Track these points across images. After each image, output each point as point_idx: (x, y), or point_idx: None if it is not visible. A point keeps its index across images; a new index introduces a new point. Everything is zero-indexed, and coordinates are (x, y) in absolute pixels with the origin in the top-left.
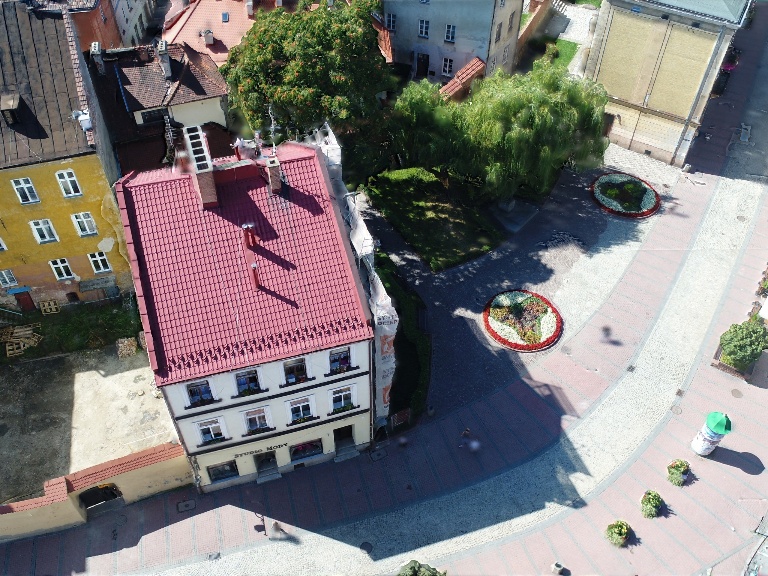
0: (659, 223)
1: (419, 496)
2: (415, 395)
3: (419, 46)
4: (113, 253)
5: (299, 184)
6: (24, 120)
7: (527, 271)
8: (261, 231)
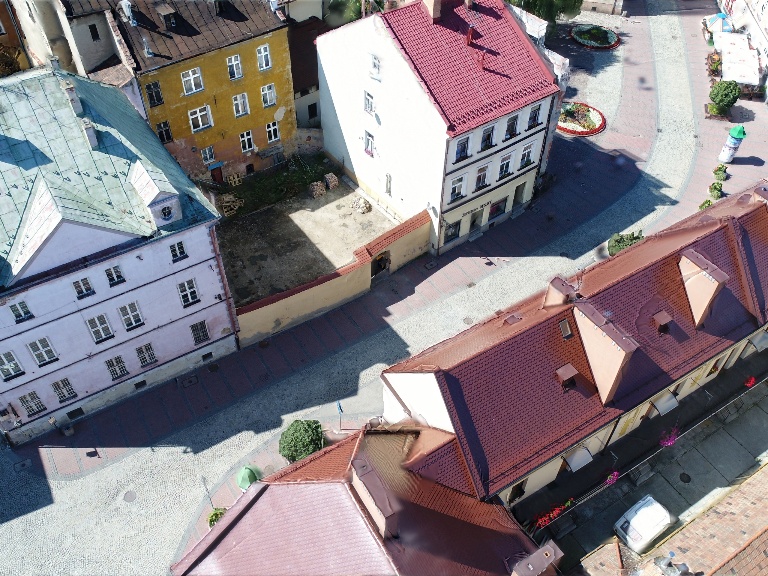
0: (626, 49)
1: (578, 223)
2: None
3: None
4: (283, 122)
5: (481, 1)
6: (227, 9)
7: None
8: None
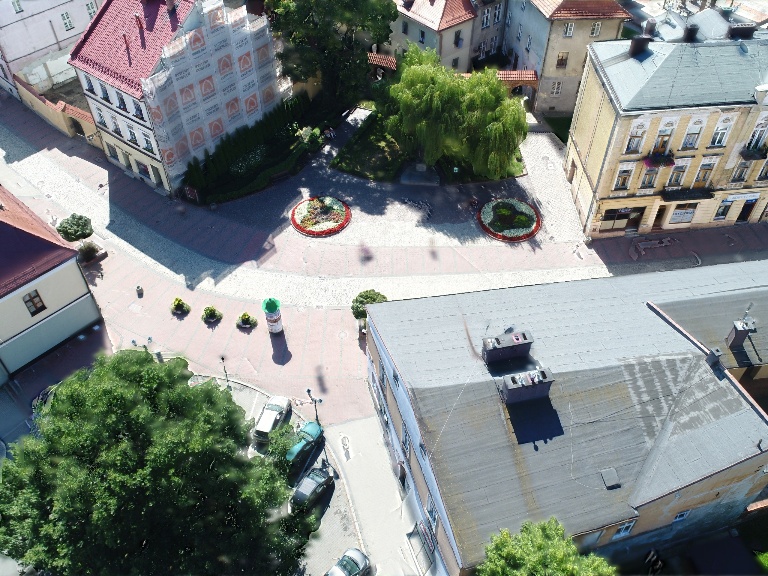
0: (496, 247)
1: (155, 227)
2: (217, 195)
3: (516, 45)
4: None
5: (180, 13)
6: None
7: (371, 203)
8: (150, 25)
